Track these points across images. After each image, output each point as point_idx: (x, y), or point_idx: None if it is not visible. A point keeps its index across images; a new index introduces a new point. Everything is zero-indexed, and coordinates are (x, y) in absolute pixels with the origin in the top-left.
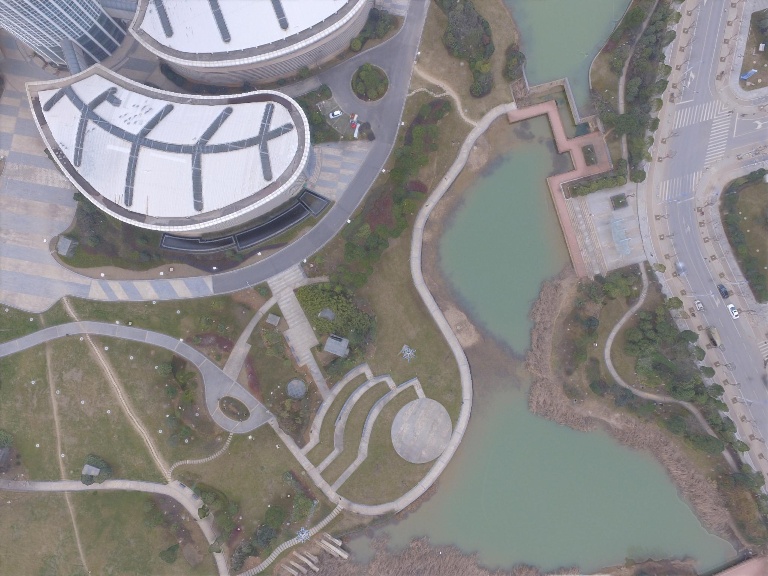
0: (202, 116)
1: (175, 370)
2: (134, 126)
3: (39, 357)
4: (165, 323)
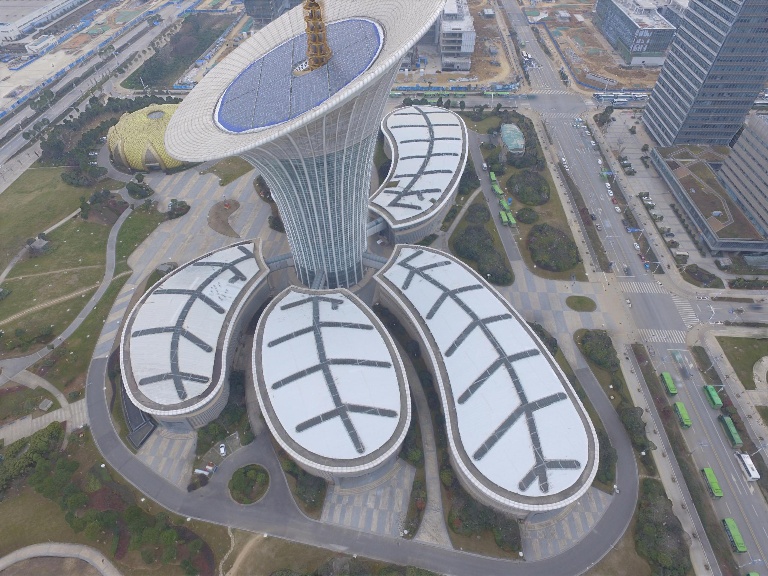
0: (208, 332)
1: (42, 337)
2: (209, 291)
3: (97, 262)
4: (84, 328)
